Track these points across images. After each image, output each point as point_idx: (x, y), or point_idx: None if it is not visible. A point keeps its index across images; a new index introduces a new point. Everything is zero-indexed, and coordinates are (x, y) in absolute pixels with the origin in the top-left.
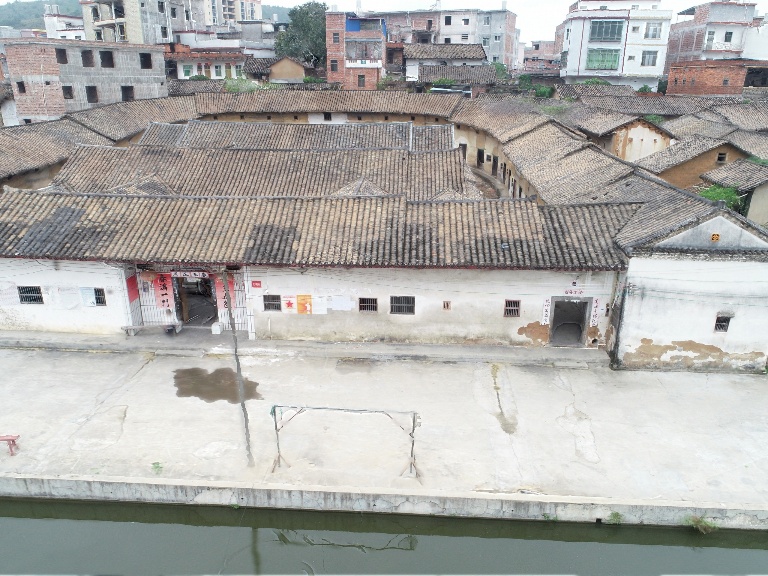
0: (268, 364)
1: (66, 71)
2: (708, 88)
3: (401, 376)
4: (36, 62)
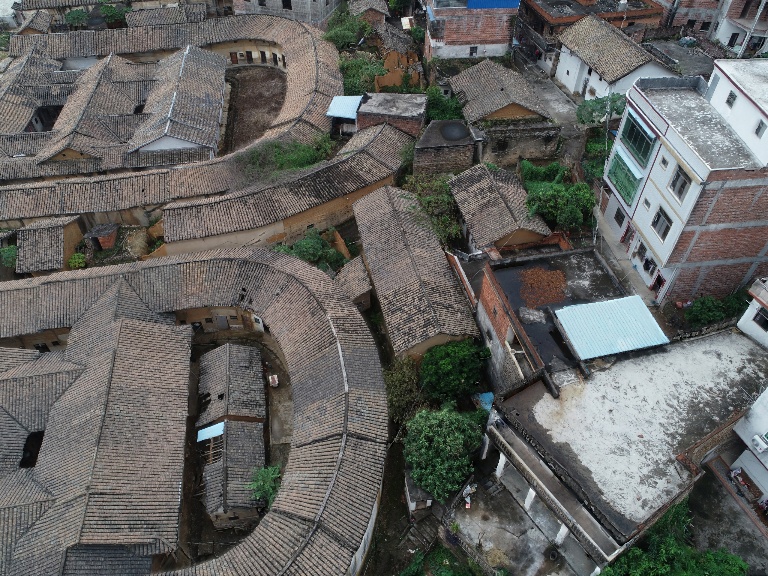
0: None
1: None
2: None
3: None
4: None
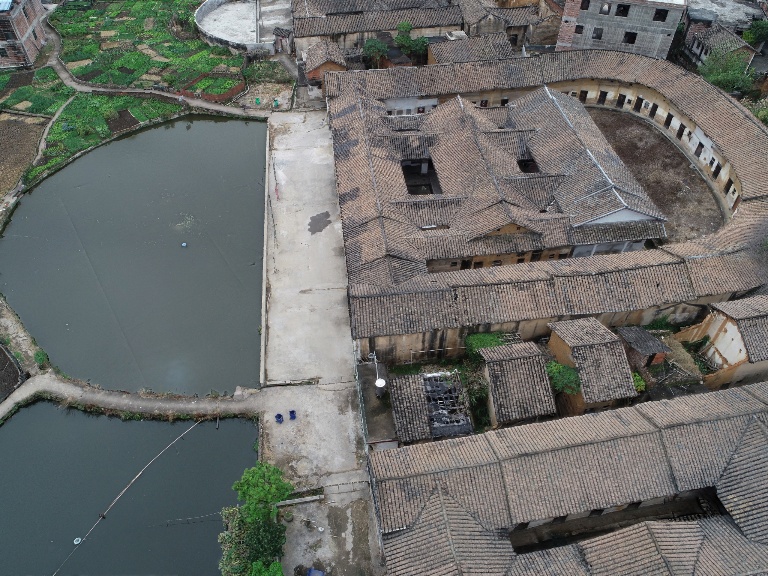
0: (336, 230)
1: (584, 15)
2: None
3: (333, 264)
4: (565, 7)
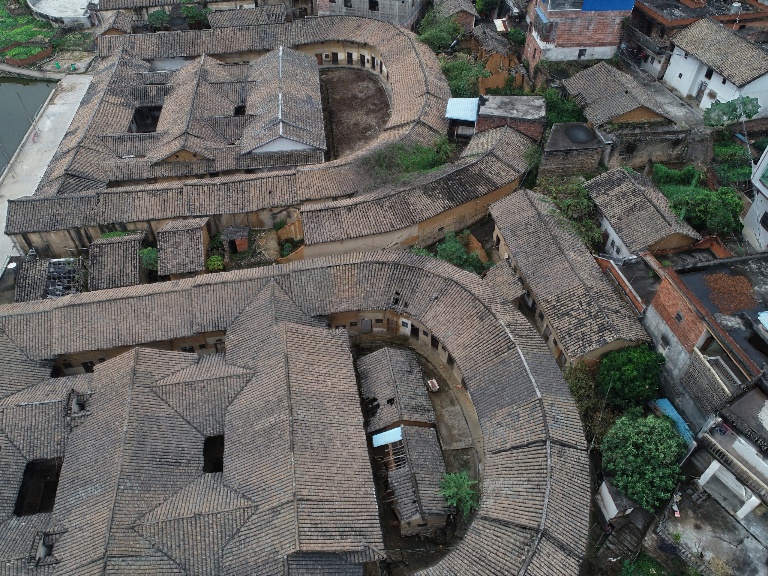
0: None
1: None
2: (660, 304)
3: None
4: None
